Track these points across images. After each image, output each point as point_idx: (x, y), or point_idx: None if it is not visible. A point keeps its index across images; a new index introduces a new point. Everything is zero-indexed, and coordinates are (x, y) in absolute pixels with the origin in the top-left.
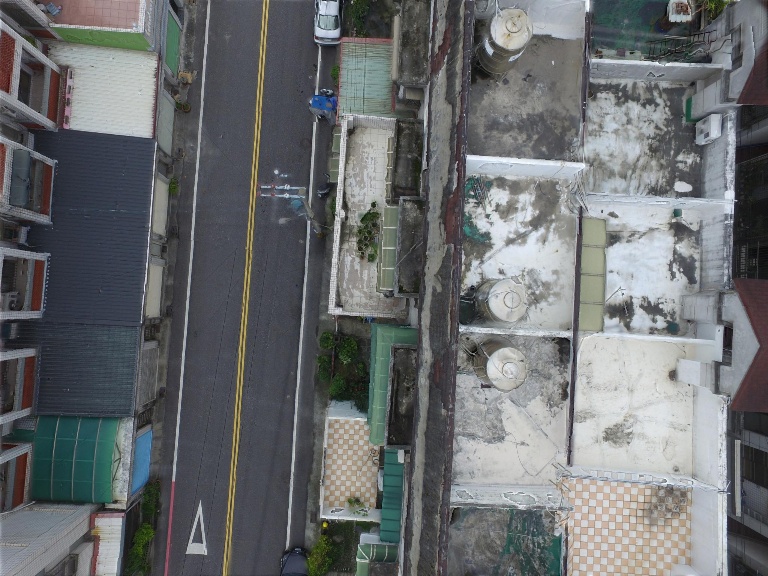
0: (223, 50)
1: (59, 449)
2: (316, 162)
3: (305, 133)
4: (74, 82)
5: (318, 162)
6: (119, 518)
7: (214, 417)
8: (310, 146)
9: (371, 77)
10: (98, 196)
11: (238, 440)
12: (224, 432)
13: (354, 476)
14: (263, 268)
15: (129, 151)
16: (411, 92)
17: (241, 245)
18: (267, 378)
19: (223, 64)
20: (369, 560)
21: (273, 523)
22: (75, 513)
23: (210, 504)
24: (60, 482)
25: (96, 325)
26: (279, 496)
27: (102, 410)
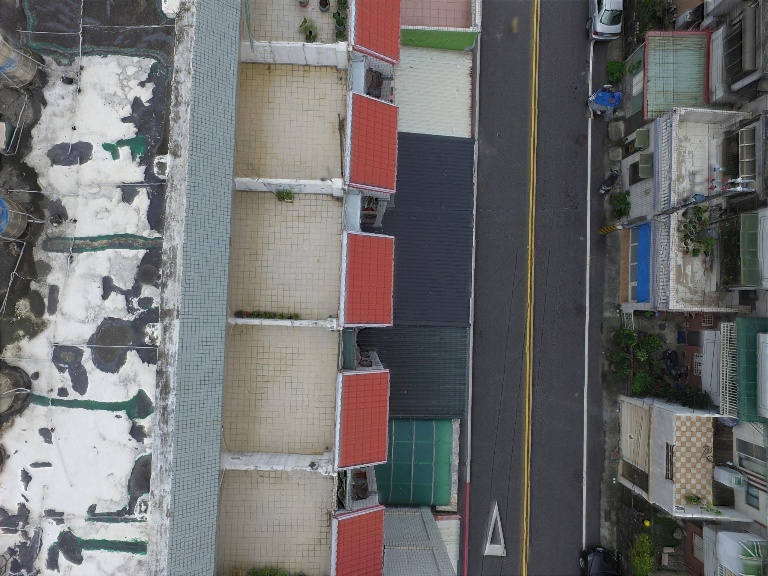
0: (495, 48)
1: (398, 452)
2: (592, 158)
3: (581, 129)
4: (395, 83)
5: (594, 158)
6: (456, 520)
7: (504, 417)
8: (586, 142)
9: (680, 70)
10: (423, 197)
11: (530, 440)
12: (515, 432)
13: (689, 473)
14: (545, 266)
15: (450, 151)
16: (765, 83)
17: (523, 244)
18: (555, 377)
19: (496, 63)
20: (757, 557)
21: (568, 523)
22: (423, 516)
23: (506, 505)
24: (399, 485)
25: (428, 326)
26: (573, 495)
27: (438, 412)
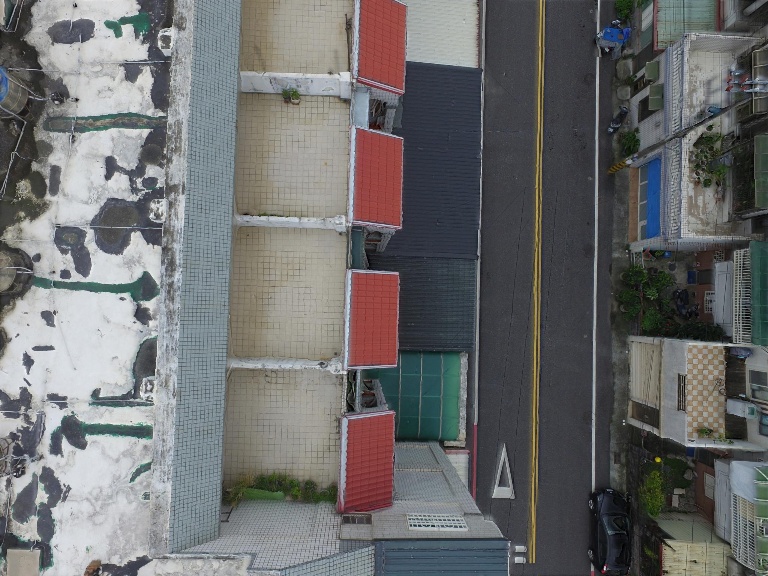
0: None
1: (405, 385)
2: (601, 97)
3: (589, 68)
4: None
5: (603, 97)
6: (465, 454)
7: (512, 359)
8: (594, 81)
9: (690, 0)
10: (430, 127)
11: (539, 381)
12: (523, 374)
13: (701, 406)
14: (553, 206)
15: (457, 81)
16: None
17: (530, 184)
18: (564, 318)
19: (502, 1)
20: None
21: (577, 465)
22: (432, 448)
23: (514, 447)
24: (407, 418)
25: (435, 258)
26: (582, 438)
27: (446, 344)
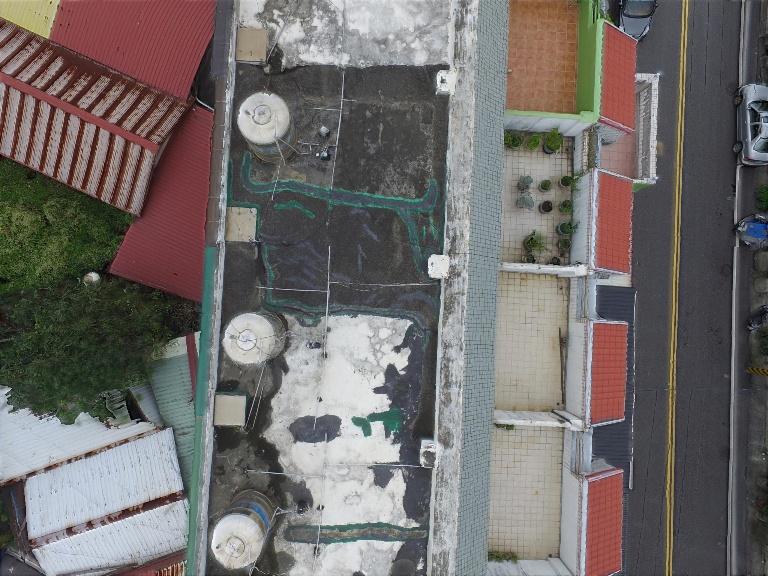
0: None
1: None
2: (737, 290)
3: (726, 259)
4: None
5: (739, 290)
6: None
7: (642, 567)
8: (731, 273)
9: None
10: None
11: None
12: None
13: None
14: (687, 405)
15: (610, 302)
16: None
17: (663, 381)
18: (697, 524)
19: None
20: None
21: None
22: None
23: None
24: None
25: None
26: None
27: None
